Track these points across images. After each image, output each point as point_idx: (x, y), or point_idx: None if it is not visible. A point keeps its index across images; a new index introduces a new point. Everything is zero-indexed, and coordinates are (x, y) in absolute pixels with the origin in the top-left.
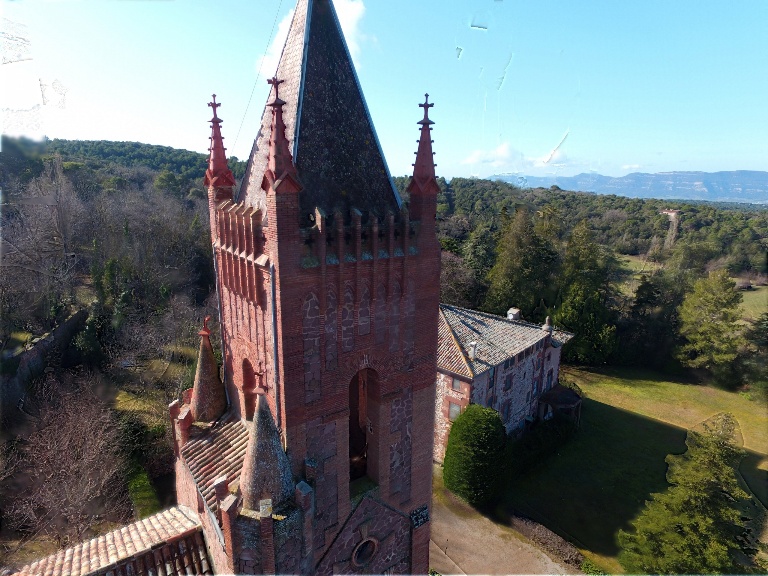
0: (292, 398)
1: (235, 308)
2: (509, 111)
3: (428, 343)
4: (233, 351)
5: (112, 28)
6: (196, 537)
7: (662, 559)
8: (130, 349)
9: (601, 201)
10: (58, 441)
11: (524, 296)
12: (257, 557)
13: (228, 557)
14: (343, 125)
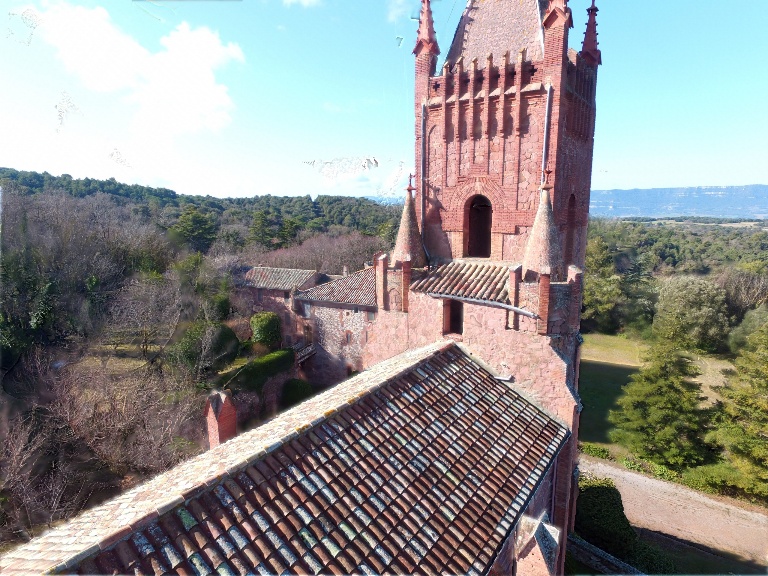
0: (555, 201)
1: (458, 154)
2: None
3: (588, 188)
4: (445, 199)
5: None
6: (455, 350)
7: (650, 418)
8: (110, 324)
9: None
10: (77, 411)
11: None
12: (565, 316)
13: (541, 320)
14: (548, 1)
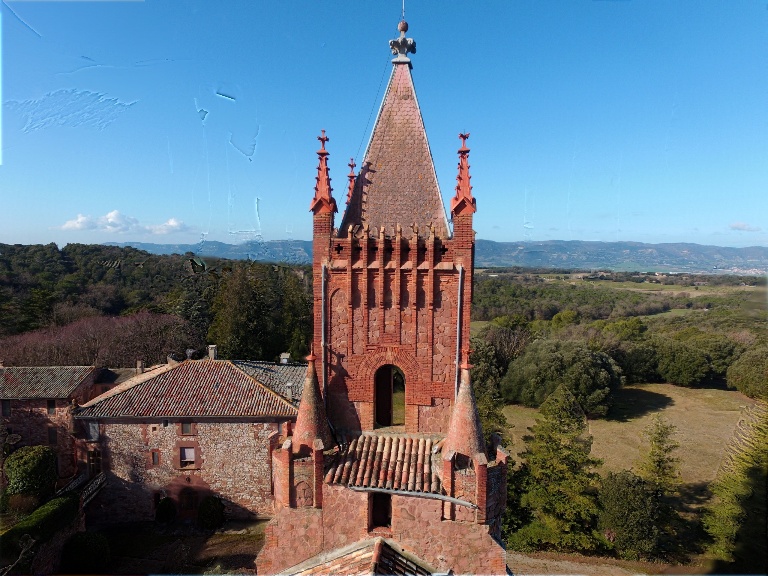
0: None
1: (366, 322)
2: (241, 175)
3: None
4: (351, 367)
5: (50, 14)
6: (386, 550)
7: None
8: None
9: (308, 257)
10: None
11: (252, 349)
12: (497, 498)
13: (480, 510)
14: None
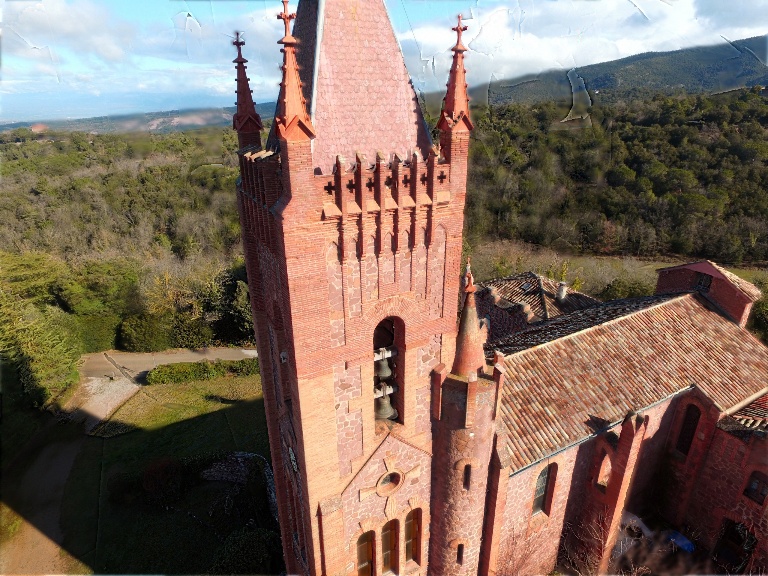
0: None
1: None
2: None
3: None
4: None
5: None
6: None
7: None
8: None
9: None
10: None
11: None
12: None
13: None
14: None
